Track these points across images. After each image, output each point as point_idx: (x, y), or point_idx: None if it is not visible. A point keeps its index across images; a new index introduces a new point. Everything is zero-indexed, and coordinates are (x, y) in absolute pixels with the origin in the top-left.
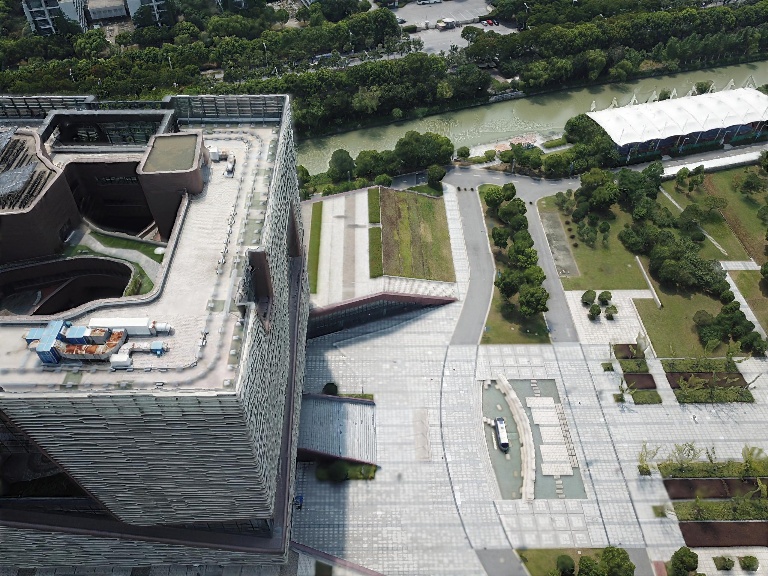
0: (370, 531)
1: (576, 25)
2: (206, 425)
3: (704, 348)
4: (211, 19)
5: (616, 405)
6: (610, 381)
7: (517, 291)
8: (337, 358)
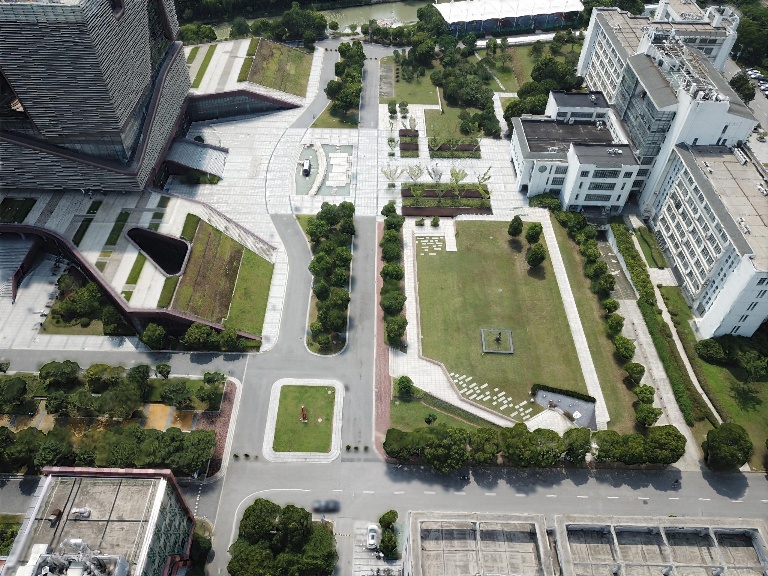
0: None
1: None
2: (70, 32)
3: (461, 133)
4: None
5: (388, 157)
6: (389, 147)
7: (338, 94)
8: (210, 131)
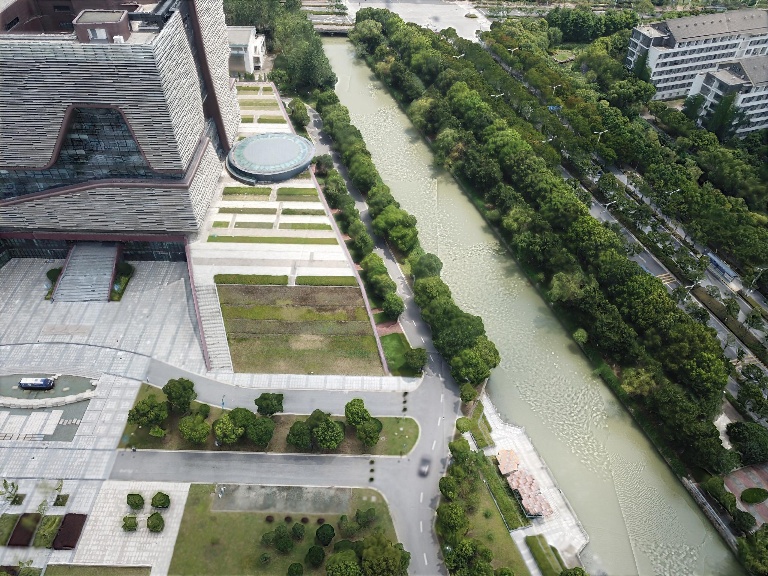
0: (7, 296)
1: None
2: None
3: None
4: None
5: None
6: (43, 497)
7: None
8: (166, 280)
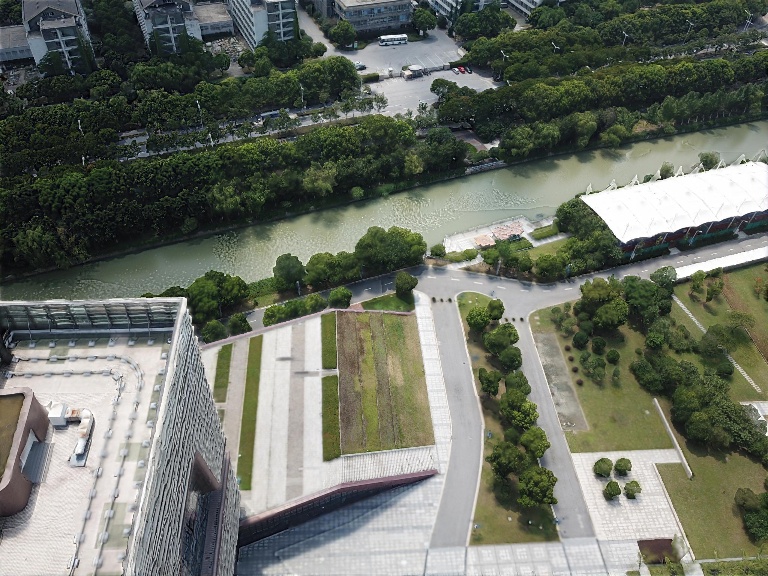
0: None
1: (561, 81)
2: None
3: (752, 541)
4: (135, 67)
5: None
6: None
7: (515, 471)
8: None
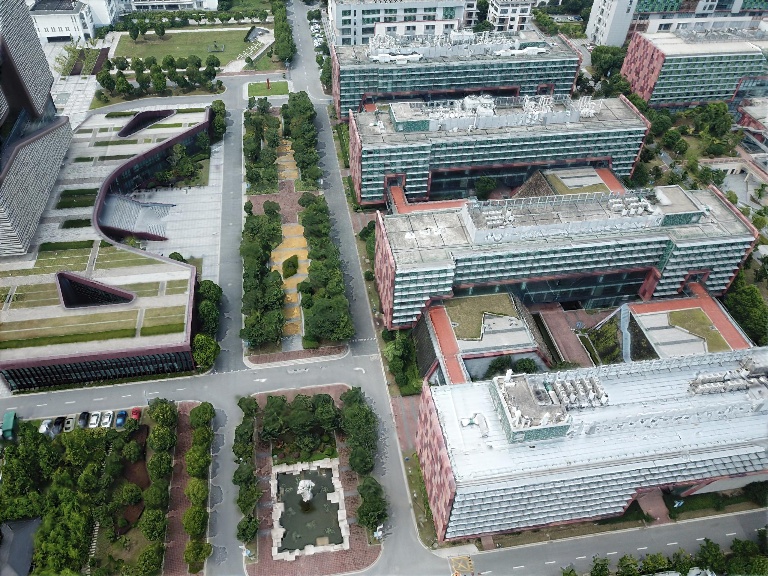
0: None
1: None
2: None
3: None
4: None
5: None
6: None
7: None
8: None
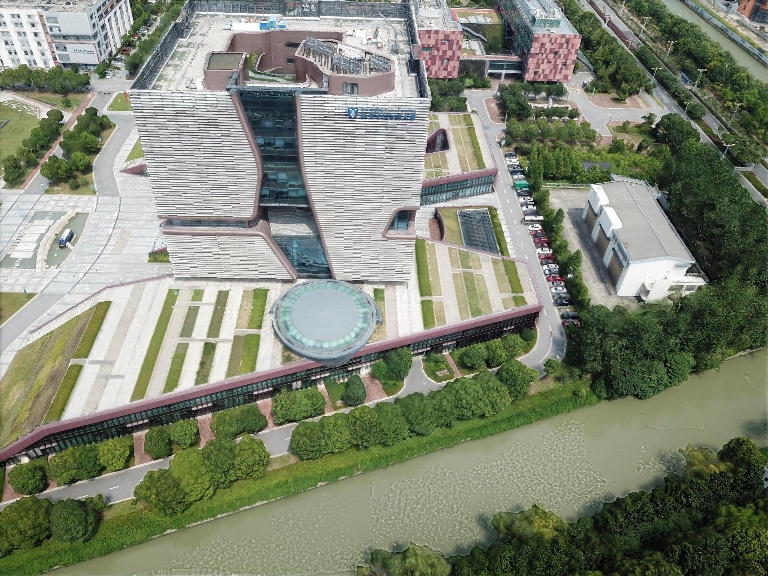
0: None
1: None
2: None
3: None
4: None
5: None
6: None
7: None
8: None
